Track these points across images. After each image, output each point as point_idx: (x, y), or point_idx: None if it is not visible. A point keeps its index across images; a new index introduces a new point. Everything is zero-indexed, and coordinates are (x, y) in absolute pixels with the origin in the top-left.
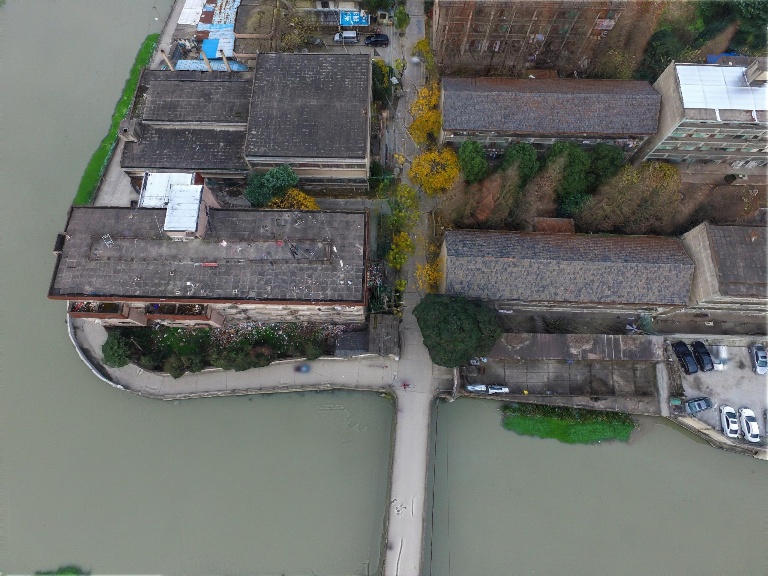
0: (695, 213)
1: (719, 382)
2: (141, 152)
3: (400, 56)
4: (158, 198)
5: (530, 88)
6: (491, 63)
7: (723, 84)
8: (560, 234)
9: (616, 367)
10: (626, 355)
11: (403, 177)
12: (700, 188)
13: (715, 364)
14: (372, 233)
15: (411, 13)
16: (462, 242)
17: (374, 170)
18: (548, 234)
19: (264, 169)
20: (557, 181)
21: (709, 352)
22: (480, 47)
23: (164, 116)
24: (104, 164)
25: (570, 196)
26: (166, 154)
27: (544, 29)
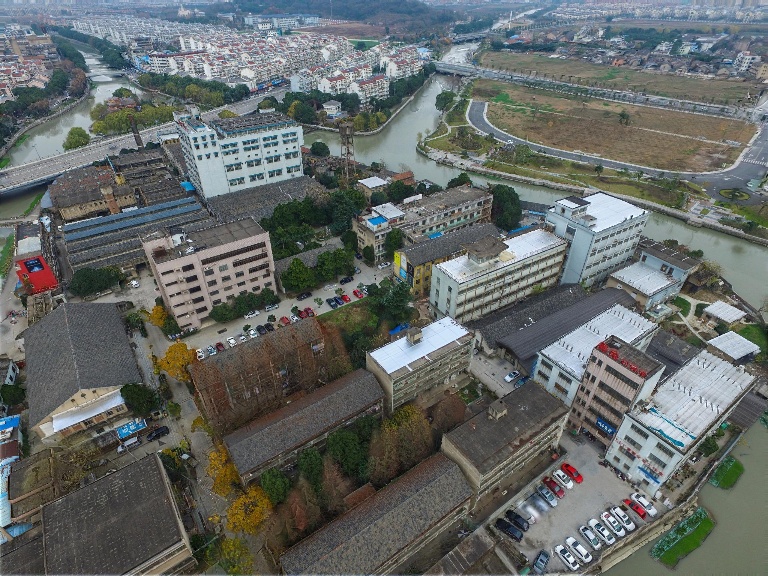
0: (443, 426)
1: (540, 532)
2: None
3: None
4: None
5: (290, 412)
6: (258, 403)
7: (400, 351)
8: (366, 500)
9: (473, 575)
10: (470, 560)
11: (224, 533)
12: (437, 407)
13: (528, 520)
14: None
15: (180, 400)
16: (297, 558)
17: (195, 543)
18: (358, 506)
19: None
20: (344, 461)
21: (519, 514)
22: (245, 397)
23: None
24: None
25: (359, 466)
26: None
27: (283, 367)
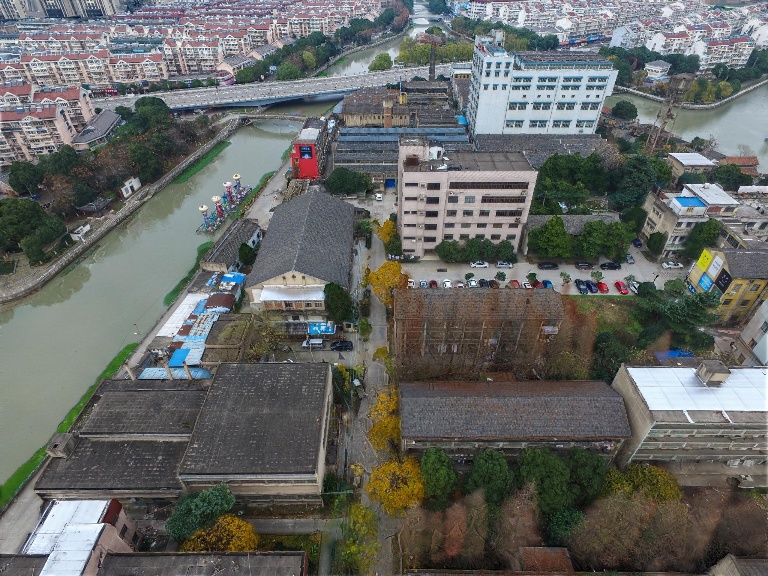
0: (712, 529)
1: None
2: (65, 470)
3: (364, 359)
4: (54, 536)
5: (488, 392)
6: (451, 363)
7: (680, 385)
8: (554, 573)
9: None
10: None
11: (360, 492)
12: (704, 493)
13: None
14: (323, 568)
15: (375, 322)
16: None
17: (328, 484)
18: (539, 574)
19: (200, 487)
20: (537, 494)
21: None
22: (439, 349)
23: (105, 428)
24: (26, 480)
25: (557, 513)
26: (93, 471)
27: (495, 335)
